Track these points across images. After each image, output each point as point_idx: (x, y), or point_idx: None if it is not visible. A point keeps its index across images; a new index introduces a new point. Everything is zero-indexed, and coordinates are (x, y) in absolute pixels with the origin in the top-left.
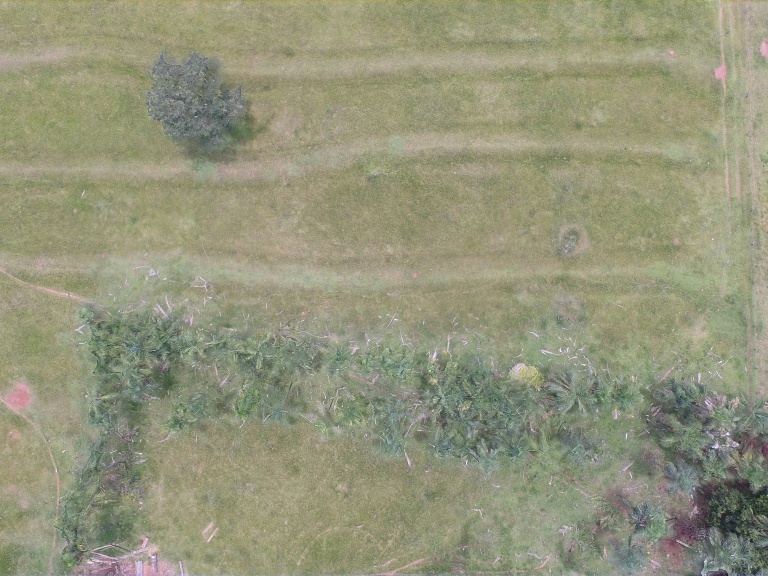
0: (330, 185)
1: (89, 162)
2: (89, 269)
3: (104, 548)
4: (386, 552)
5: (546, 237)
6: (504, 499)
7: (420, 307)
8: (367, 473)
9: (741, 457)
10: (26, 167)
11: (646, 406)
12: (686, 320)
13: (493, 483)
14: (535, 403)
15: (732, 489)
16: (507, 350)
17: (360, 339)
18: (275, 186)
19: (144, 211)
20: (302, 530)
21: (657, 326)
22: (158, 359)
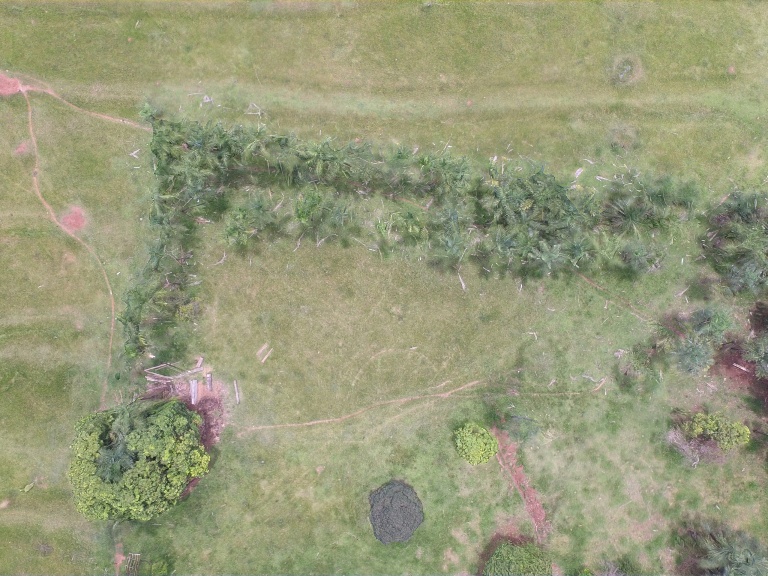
0: (383, 15)
1: None
2: (143, 96)
3: (159, 367)
4: (441, 374)
5: (600, 66)
6: (559, 322)
7: (474, 134)
8: (421, 296)
9: None
10: None
11: (702, 231)
12: (742, 148)
13: (548, 307)
14: (590, 228)
15: None
16: (562, 176)
17: (414, 165)
18: (328, 17)
19: (198, 40)
20: (356, 351)
21: (713, 153)
22: (219, 160)
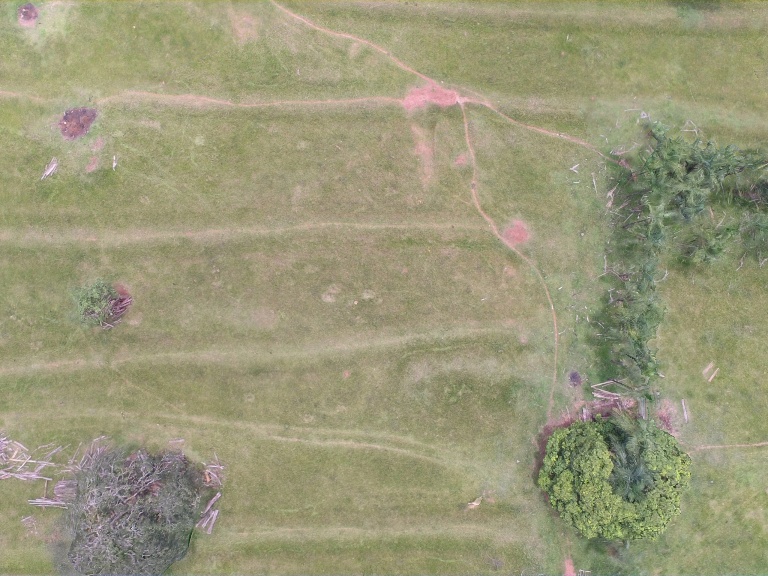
0: None
1: (574, 6)
2: (579, 110)
3: (606, 384)
4: None
5: None
6: None
7: None
8: None
9: None
10: (512, 9)
11: None
12: None
13: None
14: None
15: None
16: None
17: None
18: (759, 35)
19: (630, 56)
20: None
21: None
22: (717, 180)
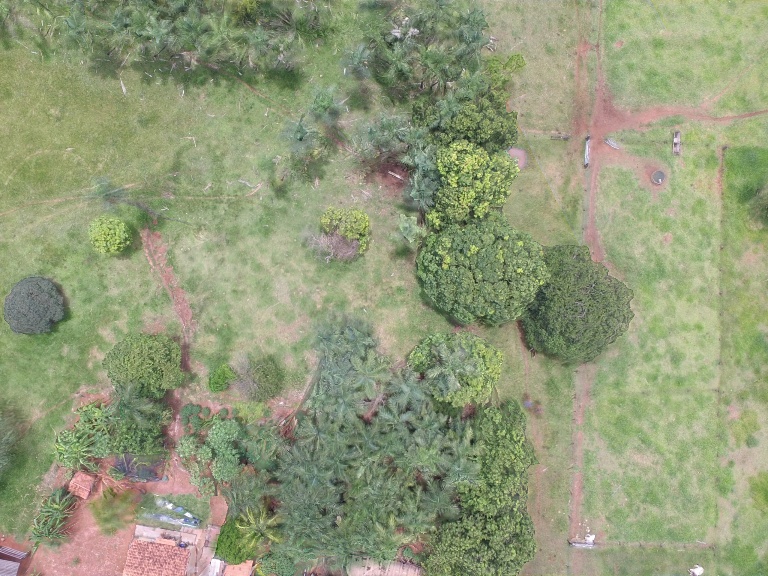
0: None
1: None
2: None
3: None
4: (96, 175)
5: None
6: (218, 128)
7: None
8: (81, 99)
9: (426, 50)
10: None
11: (366, 42)
12: None
13: (208, 113)
14: None
15: (426, 96)
16: None
17: None
18: None
19: None
20: (11, 151)
21: None
22: None
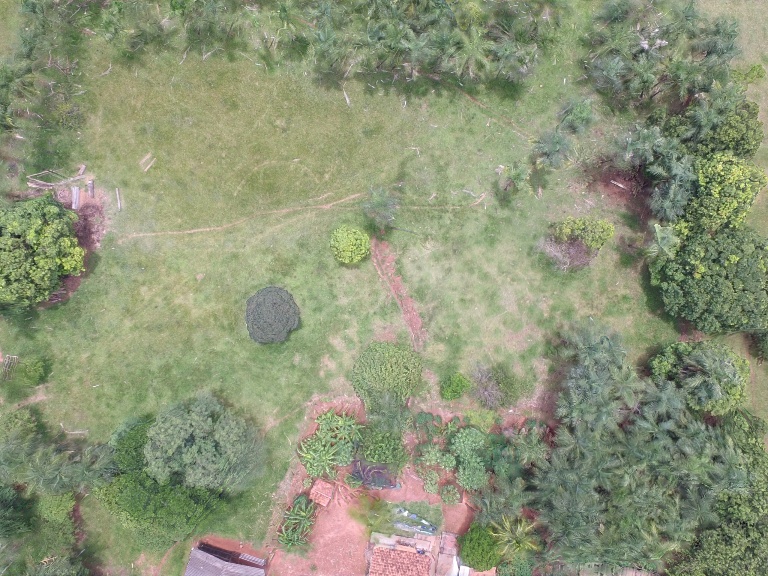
0: None
1: None
2: None
3: (41, 174)
4: (323, 186)
5: None
6: (441, 138)
7: None
8: (306, 110)
9: (671, 61)
10: None
11: (585, 53)
12: None
13: (431, 123)
14: None
15: None
16: None
17: None
18: None
19: None
20: (239, 162)
21: None
22: None
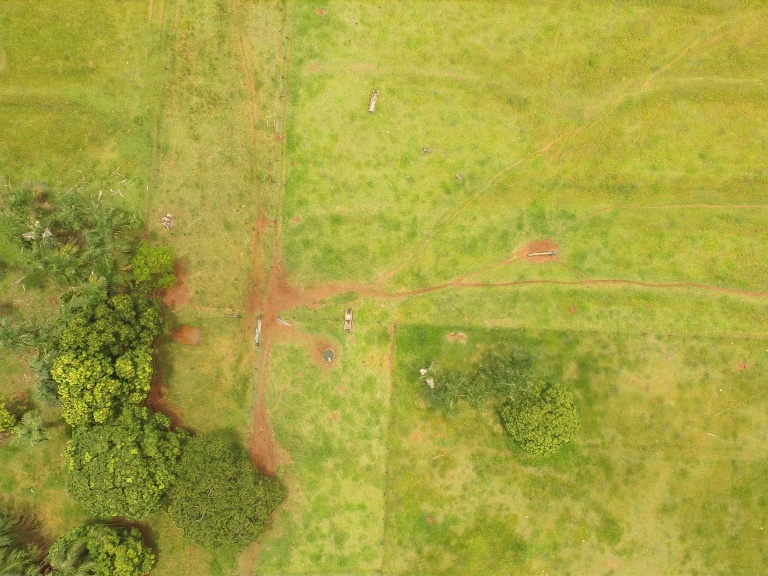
0: None
1: None
2: None
3: None
4: None
5: None
6: None
7: None
8: None
9: None
10: None
11: None
12: (94, 140)
13: None
14: None
15: None
16: None
17: None
18: None
19: None
20: None
21: (64, 145)
22: None
